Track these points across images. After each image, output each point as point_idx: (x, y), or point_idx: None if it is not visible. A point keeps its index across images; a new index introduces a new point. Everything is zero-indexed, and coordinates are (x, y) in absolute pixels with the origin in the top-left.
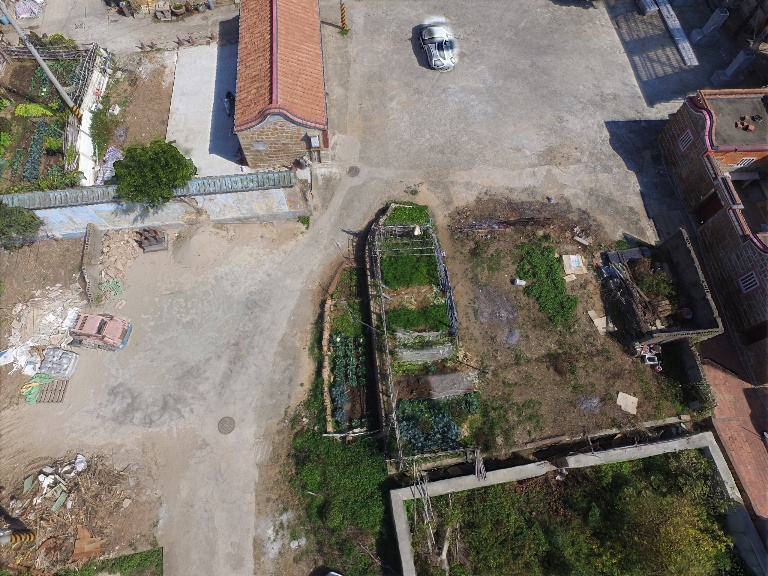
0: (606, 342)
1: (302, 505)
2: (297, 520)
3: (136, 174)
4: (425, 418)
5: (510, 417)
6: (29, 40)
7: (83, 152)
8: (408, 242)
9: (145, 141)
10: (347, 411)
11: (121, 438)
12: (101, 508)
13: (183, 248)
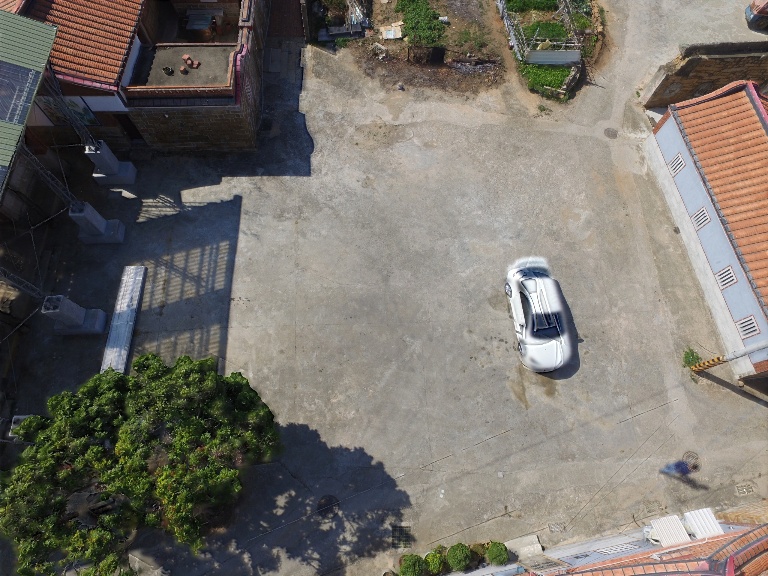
0: None
1: None
2: None
3: None
4: None
5: None
6: None
7: None
8: None
9: None
10: None
11: None
12: None
13: None
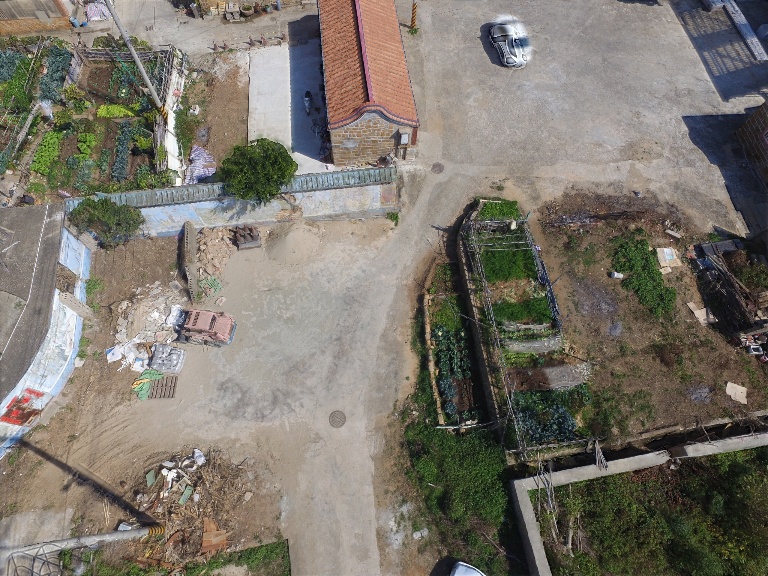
0: (709, 333)
1: (421, 497)
2: (417, 511)
3: (248, 171)
4: (539, 409)
5: (622, 408)
6: (103, 42)
7: (170, 152)
8: (503, 237)
9: (228, 140)
10: (455, 404)
11: (235, 432)
12: (226, 501)
13: (278, 245)
